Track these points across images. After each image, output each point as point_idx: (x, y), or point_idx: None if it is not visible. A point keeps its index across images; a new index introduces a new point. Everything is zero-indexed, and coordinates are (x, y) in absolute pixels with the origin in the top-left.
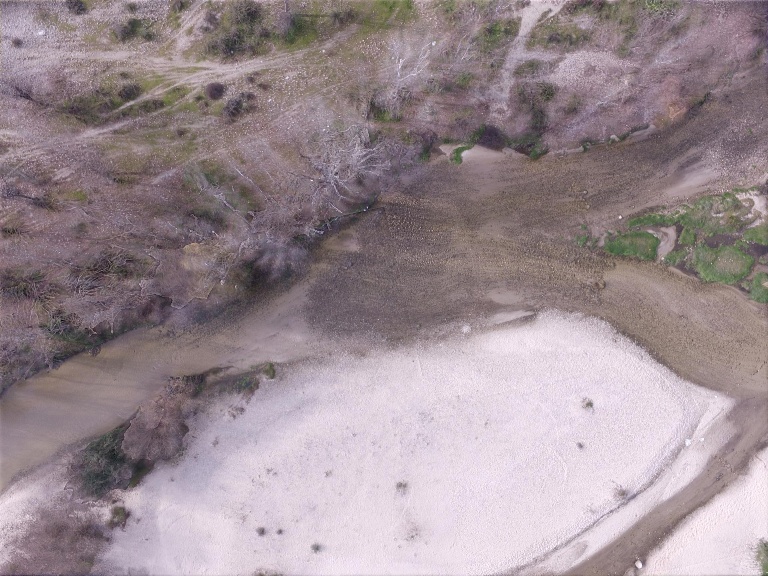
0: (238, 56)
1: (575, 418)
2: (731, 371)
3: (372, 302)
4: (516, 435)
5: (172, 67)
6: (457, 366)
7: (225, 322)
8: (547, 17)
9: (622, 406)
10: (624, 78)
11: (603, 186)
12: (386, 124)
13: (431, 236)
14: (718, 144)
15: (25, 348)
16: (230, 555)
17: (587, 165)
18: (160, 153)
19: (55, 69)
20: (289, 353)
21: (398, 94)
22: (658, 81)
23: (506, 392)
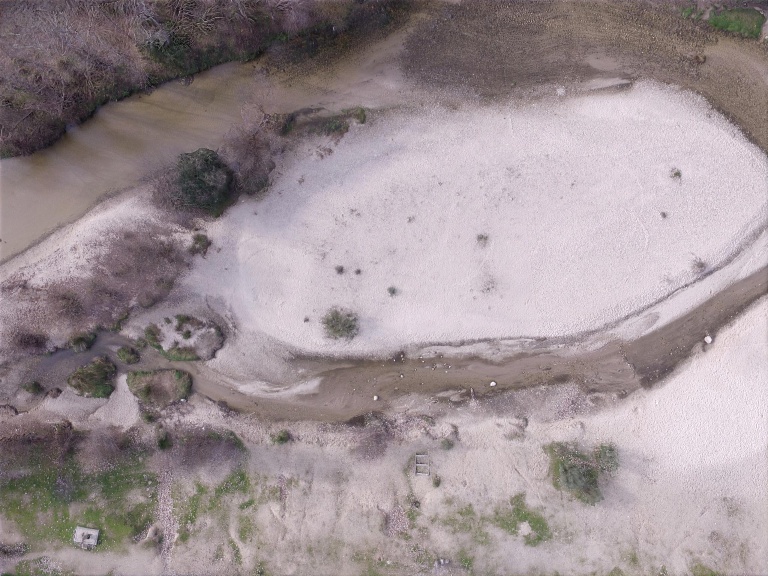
0: None
1: (662, 187)
2: None
3: (469, 56)
4: (601, 198)
5: None
6: (548, 127)
7: (319, 64)
8: None
9: (710, 179)
10: None
11: None
12: None
13: None
14: None
15: (121, 65)
16: (308, 290)
17: None
18: None
19: None
20: (381, 100)
21: None
22: None
23: (595, 155)
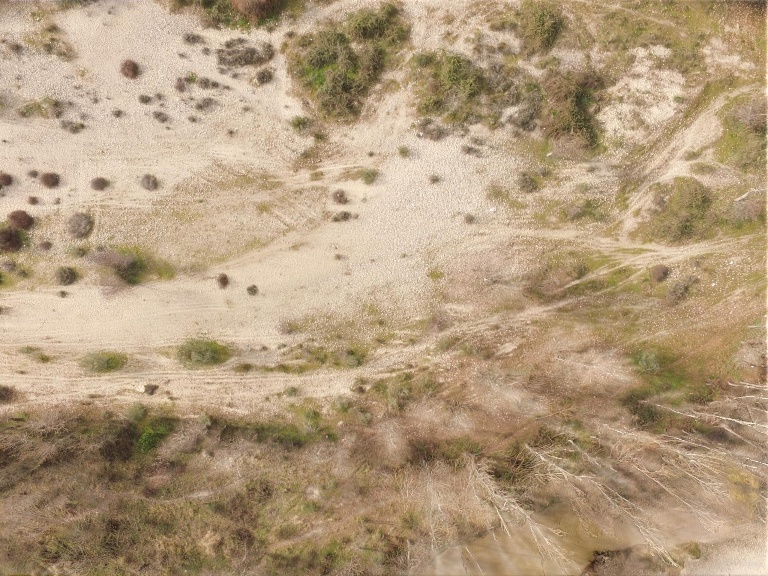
0: (685, 239)
1: None
2: None
3: None
4: None
5: (618, 248)
6: None
7: (650, 499)
8: None
9: None
10: None
11: None
12: None
13: None
14: None
15: (463, 520)
16: None
17: None
18: (602, 332)
19: (504, 246)
20: (715, 534)
21: None
22: None
23: None
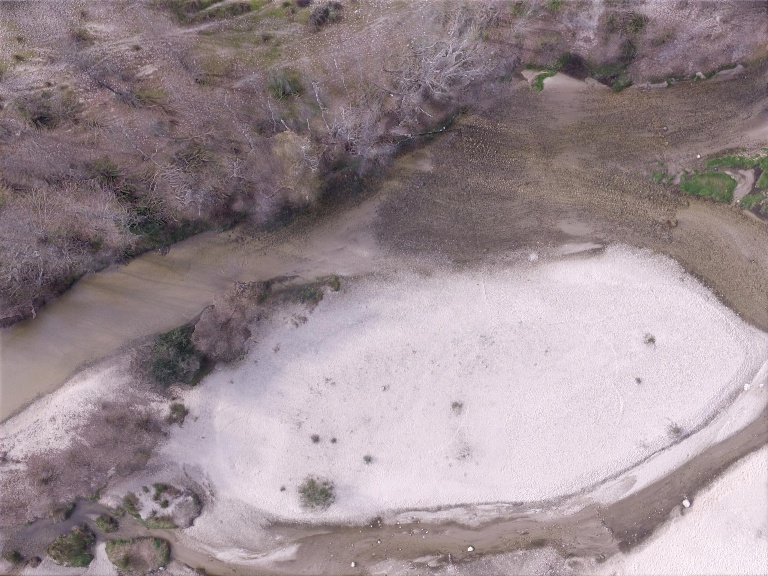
0: None
1: (636, 353)
2: None
3: (441, 223)
4: (575, 365)
5: None
6: (521, 293)
7: (294, 232)
8: None
9: (684, 345)
10: (716, 14)
11: (684, 124)
12: (471, 44)
13: (506, 161)
14: None
15: (98, 240)
16: (284, 459)
17: (669, 101)
18: (243, 57)
19: None
20: (355, 267)
21: (486, 13)
22: (751, 19)
23: (569, 322)
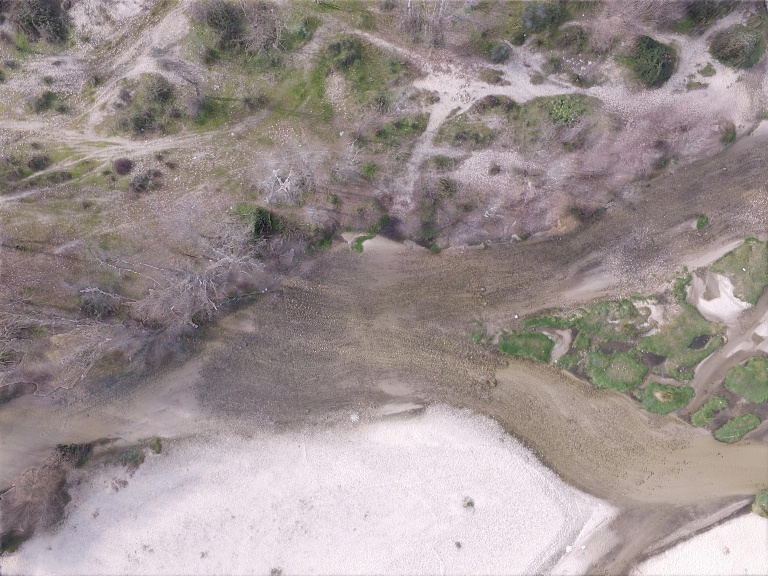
0: (148, 134)
1: (455, 516)
2: (617, 480)
3: (263, 384)
4: (395, 529)
5: (83, 140)
6: (342, 455)
7: (117, 393)
8: (455, 114)
9: (503, 508)
10: (528, 180)
11: (501, 284)
12: (289, 210)
13: (327, 322)
14: (619, 250)
15: None
16: None
17: (487, 262)
18: (65, 223)
19: None
20: (177, 429)
21: (301, 182)
22: (562, 185)
23: (388, 485)
